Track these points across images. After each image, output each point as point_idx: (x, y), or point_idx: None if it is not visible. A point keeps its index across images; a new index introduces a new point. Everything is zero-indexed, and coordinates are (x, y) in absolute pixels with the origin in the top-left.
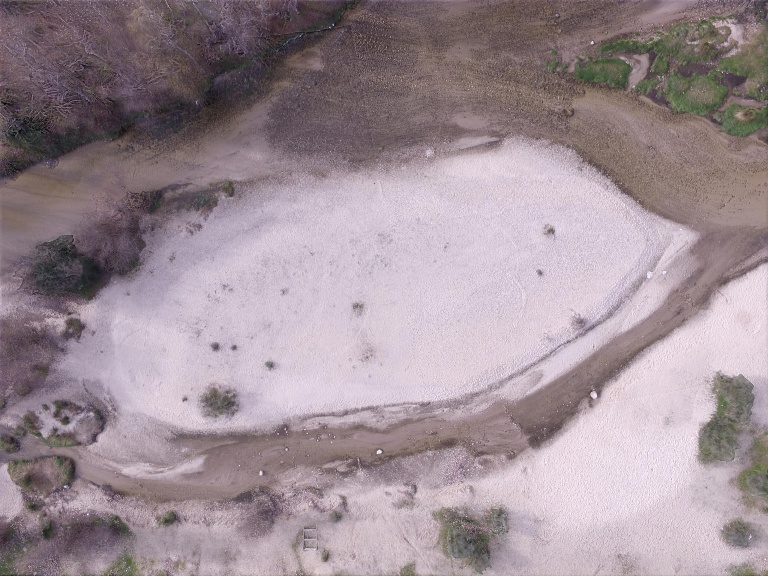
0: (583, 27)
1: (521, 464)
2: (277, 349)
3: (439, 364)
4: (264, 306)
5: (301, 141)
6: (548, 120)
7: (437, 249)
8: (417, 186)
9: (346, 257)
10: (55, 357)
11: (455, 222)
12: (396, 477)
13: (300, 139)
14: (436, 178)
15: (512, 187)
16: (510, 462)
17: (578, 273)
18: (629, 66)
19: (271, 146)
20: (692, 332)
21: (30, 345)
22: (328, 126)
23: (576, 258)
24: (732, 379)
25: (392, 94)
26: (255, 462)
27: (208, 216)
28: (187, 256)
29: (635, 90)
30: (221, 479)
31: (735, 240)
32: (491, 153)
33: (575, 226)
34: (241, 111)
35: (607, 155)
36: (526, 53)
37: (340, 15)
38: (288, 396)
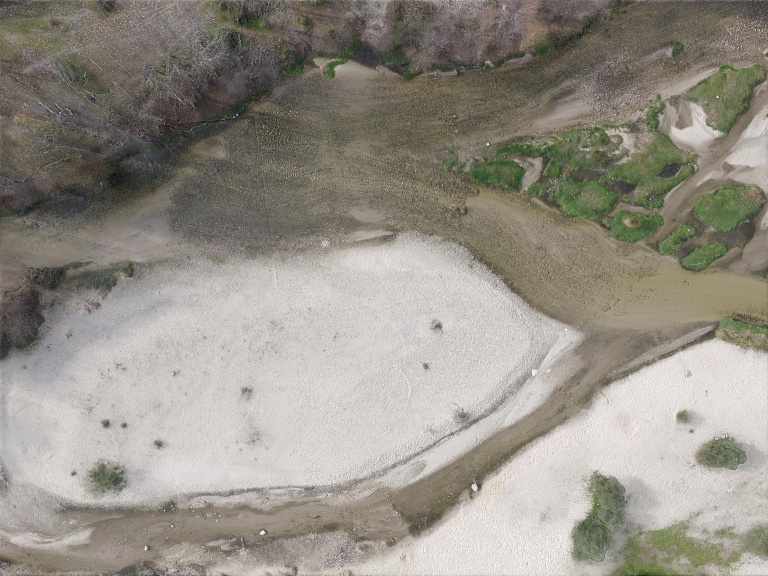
0: (480, 128)
1: (401, 551)
2: (166, 428)
3: (324, 451)
4: (155, 386)
5: (201, 226)
6: (442, 217)
7: (327, 338)
8: (311, 275)
9: (238, 342)
10: None
11: (345, 313)
12: (278, 558)
13: (200, 224)
14: (330, 268)
15: (403, 281)
16: (390, 549)
17: (463, 368)
18: (522, 169)
19: (171, 229)
20: (573, 431)
21: None
22: (228, 213)
23: (462, 354)
24: (606, 481)
25: (291, 184)
26: (141, 537)
27: (106, 295)
28: (84, 333)
29: (527, 192)
30: (107, 552)
31: (619, 343)
32: (385, 246)
33: (462, 322)
34: (144, 194)
35: (498, 254)
36: (423, 151)
37: (244, 106)
38: (175, 475)
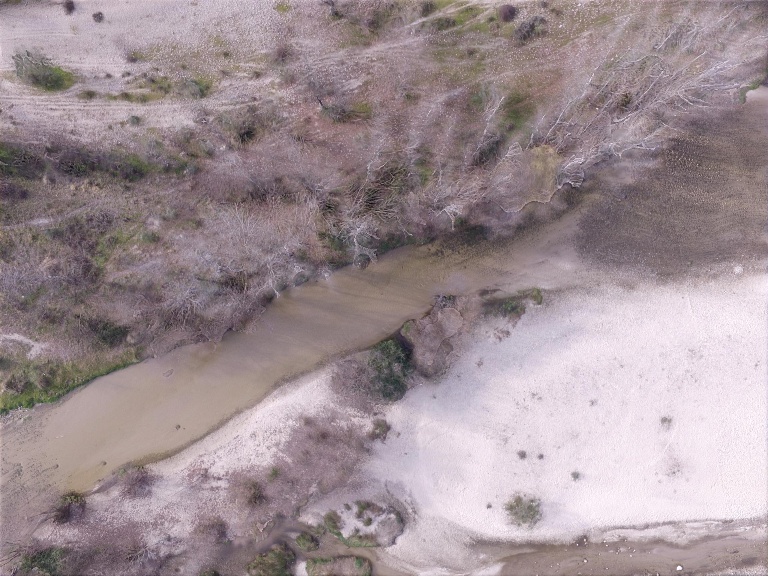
0: None
1: None
2: (583, 460)
3: (746, 483)
4: (572, 416)
5: (610, 253)
6: None
7: (748, 367)
8: (726, 302)
9: (656, 371)
10: (360, 457)
11: (766, 341)
12: None
13: (609, 251)
14: (745, 295)
15: None
16: None
17: None
18: None
19: (580, 256)
20: None
21: (337, 444)
22: (637, 239)
23: None
24: None
25: (702, 210)
26: (553, 572)
27: (516, 323)
28: (495, 362)
29: None
30: None
31: None
32: None
33: None
34: (550, 220)
35: None
36: None
37: None
38: (591, 507)
